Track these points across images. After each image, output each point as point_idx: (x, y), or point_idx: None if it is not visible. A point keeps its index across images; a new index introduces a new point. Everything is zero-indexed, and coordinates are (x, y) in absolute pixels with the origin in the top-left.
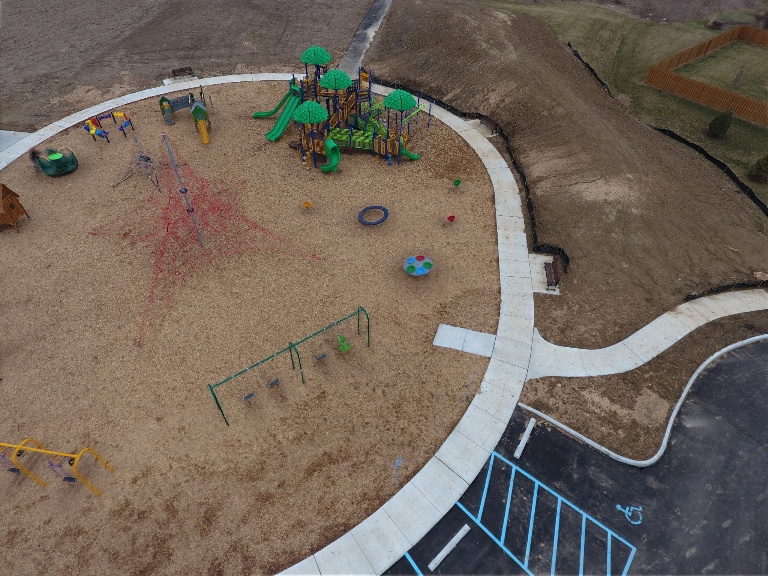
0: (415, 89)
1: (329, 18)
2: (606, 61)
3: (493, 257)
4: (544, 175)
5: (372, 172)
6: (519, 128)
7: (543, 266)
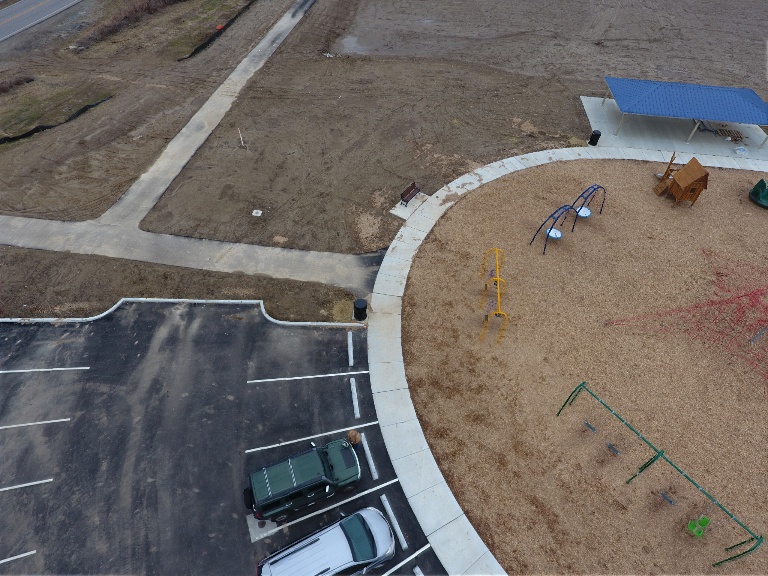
0: None
1: None
2: None
3: None
4: None
5: None
6: None
7: None
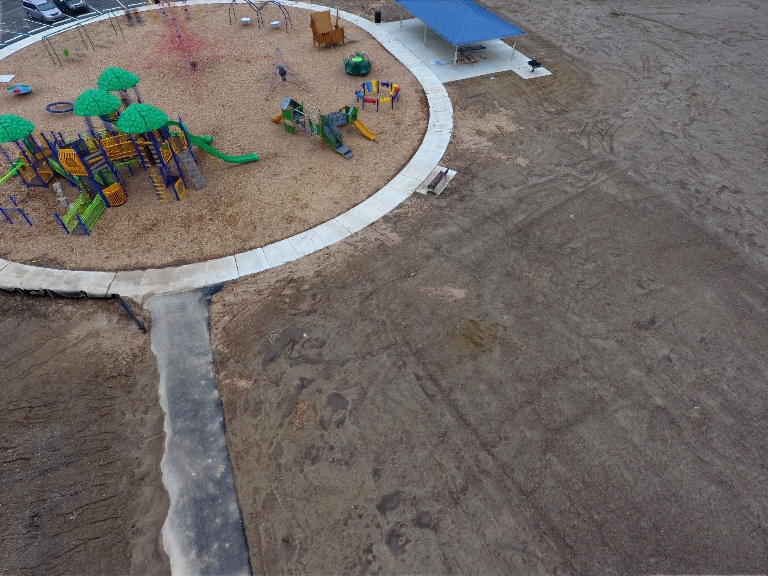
0: (7, 300)
1: None
2: None
3: None
4: None
5: None
6: None
7: None
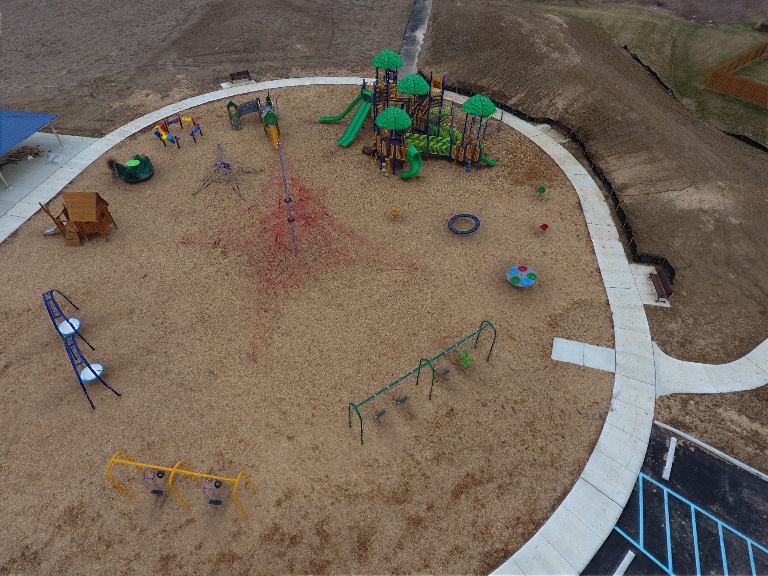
0: (477, 93)
1: (374, 20)
2: (663, 64)
3: (593, 267)
4: (629, 182)
5: (452, 179)
6: (592, 133)
7: (647, 277)
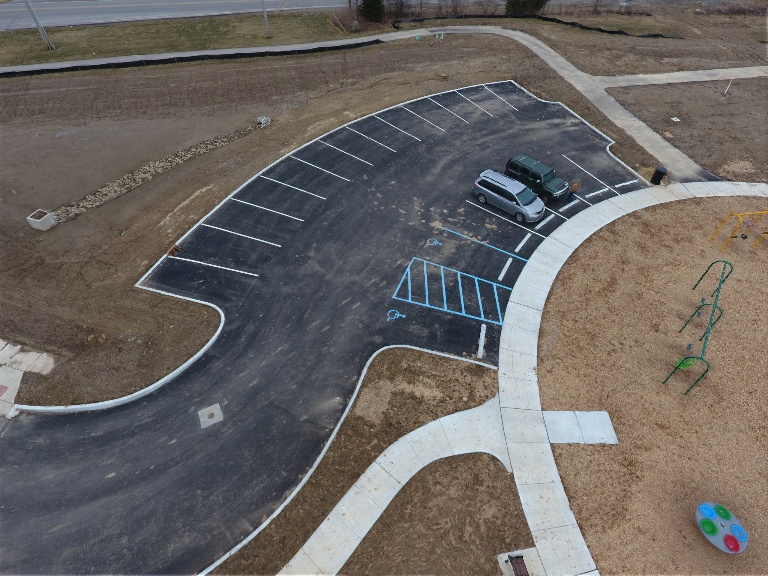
0: None
1: None
2: None
3: None
4: None
5: None
6: None
7: None
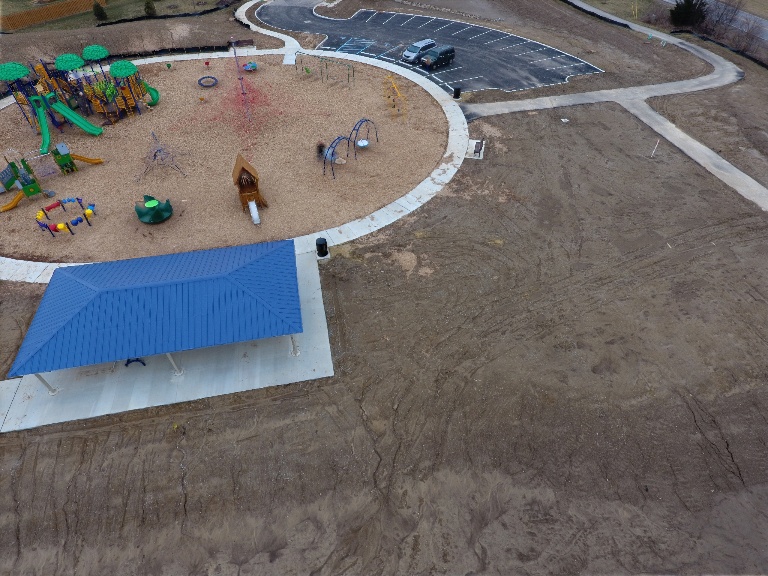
0: None
1: None
2: None
3: (234, 58)
4: (159, 46)
5: None
6: None
7: None
